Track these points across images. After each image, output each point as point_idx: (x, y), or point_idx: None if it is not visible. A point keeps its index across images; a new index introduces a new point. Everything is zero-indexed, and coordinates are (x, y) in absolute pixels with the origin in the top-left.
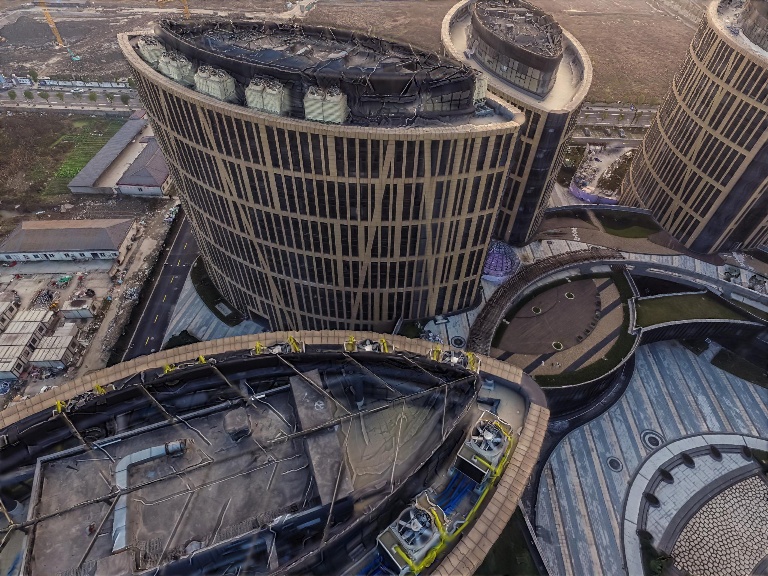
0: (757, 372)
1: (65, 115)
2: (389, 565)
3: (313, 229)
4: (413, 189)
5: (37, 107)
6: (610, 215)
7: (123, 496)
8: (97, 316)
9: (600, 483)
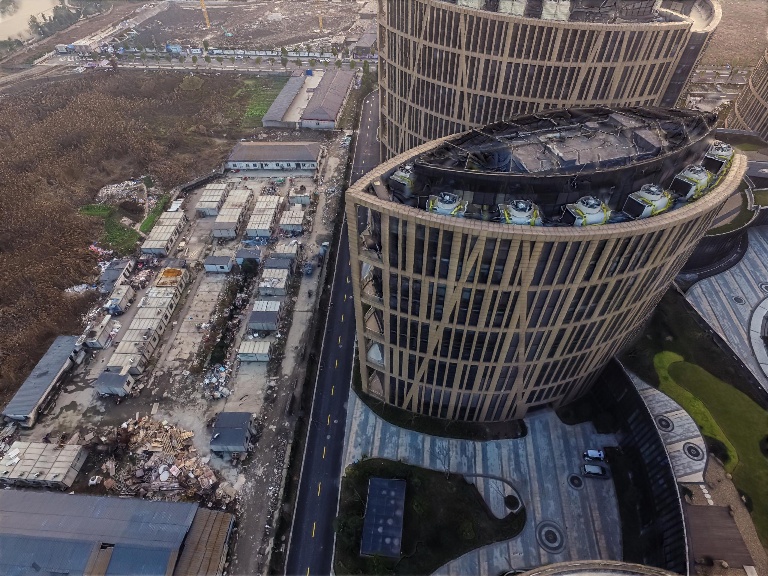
0: None
1: (235, 75)
2: (682, 189)
3: (522, 109)
4: (607, 72)
5: (213, 69)
6: (723, 135)
7: (554, 143)
8: (312, 203)
9: (728, 310)
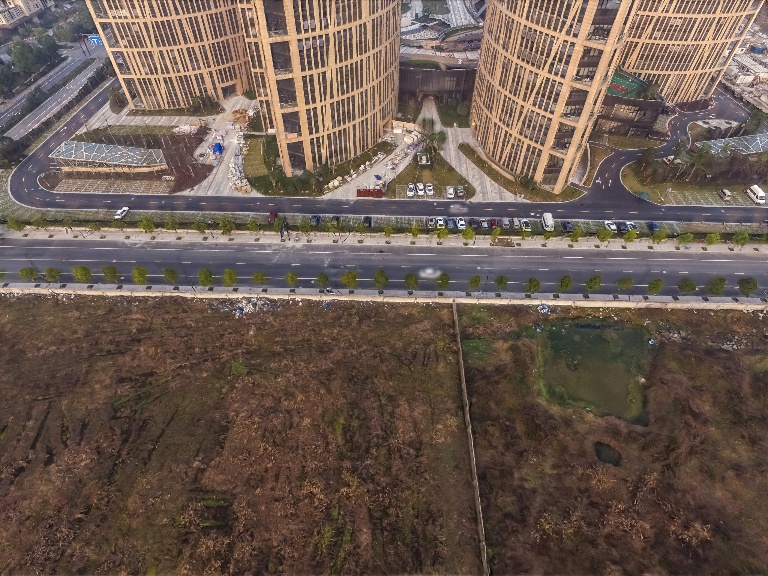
0: None
1: None
2: None
3: None
4: None
5: None
6: (432, 65)
7: None
8: (730, 80)
9: None
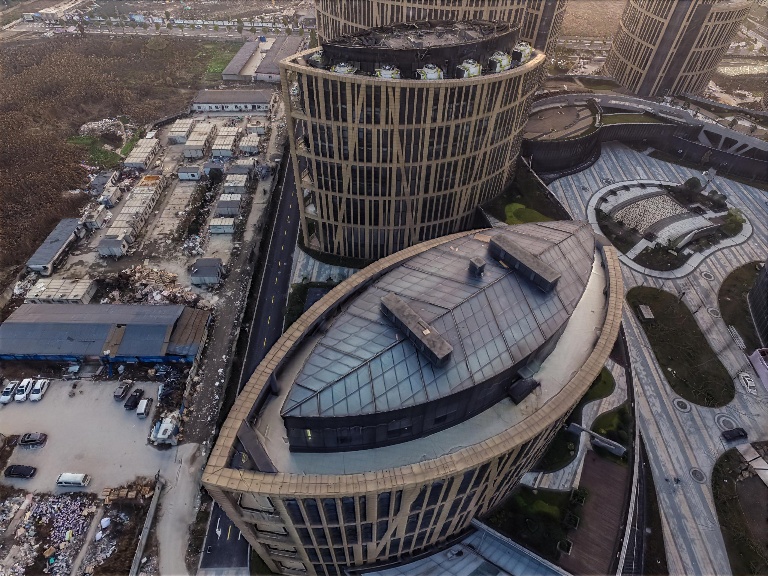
0: (674, 158)
1: (196, 41)
2: (493, 66)
3: None
4: (478, 15)
5: (175, 35)
6: (588, 79)
7: None
8: (267, 134)
9: (576, 194)
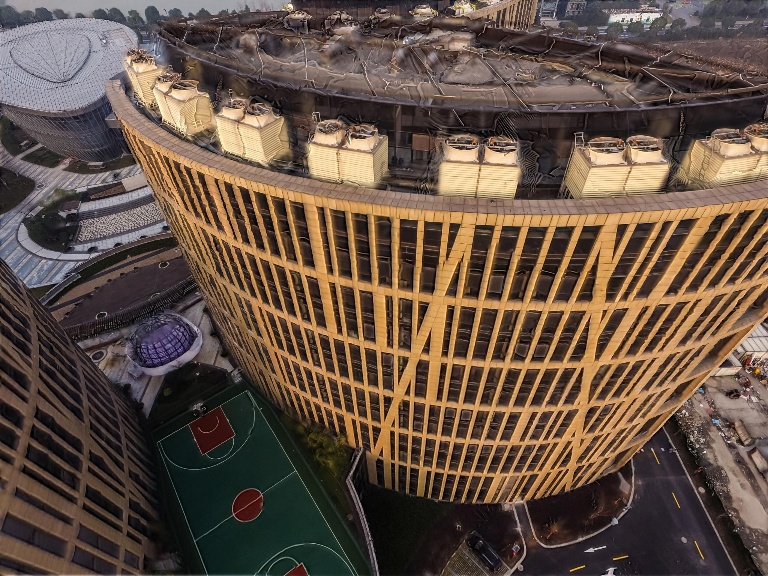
0: None
1: None
2: None
3: None
4: None
5: None
6: None
7: None
8: None
9: None
